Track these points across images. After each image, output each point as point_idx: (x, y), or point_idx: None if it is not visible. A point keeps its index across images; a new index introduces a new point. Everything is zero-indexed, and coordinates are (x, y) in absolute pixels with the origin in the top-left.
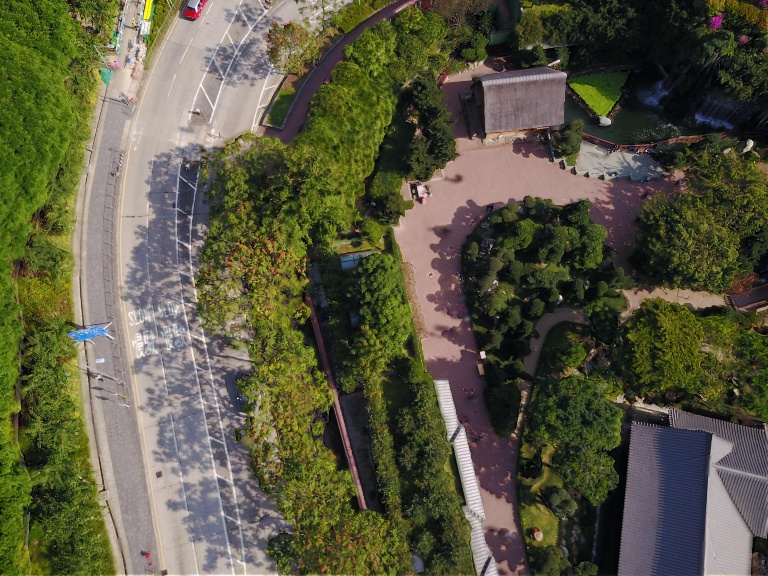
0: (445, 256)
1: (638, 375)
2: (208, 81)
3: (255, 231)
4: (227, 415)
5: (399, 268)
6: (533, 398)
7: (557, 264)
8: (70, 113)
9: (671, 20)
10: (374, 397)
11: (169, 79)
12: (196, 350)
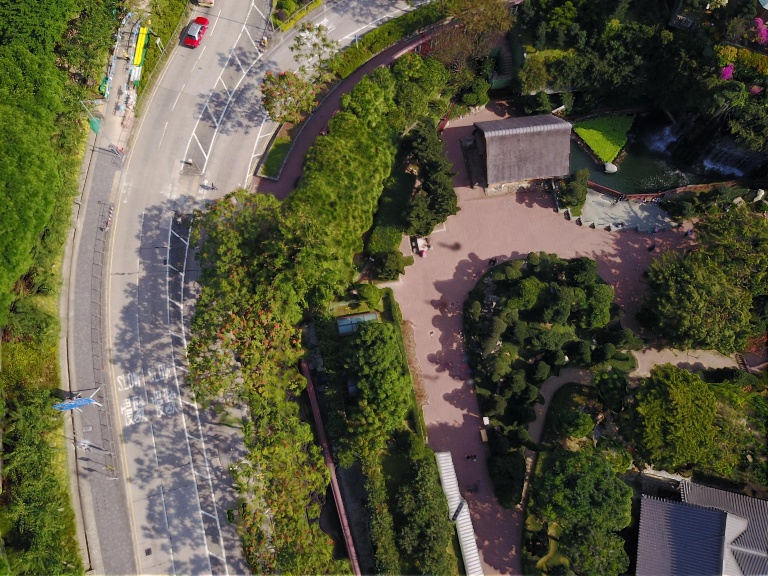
0: (446, 313)
1: (649, 450)
2: (201, 129)
3: (248, 299)
4: (220, 487)
5: (399, 332)
6: (538, 466)
7: (563, 323)
8: (56, 174)
9: (680, 69)
10: (373, 474)
11: (161, 127)
12: (187, 417)
